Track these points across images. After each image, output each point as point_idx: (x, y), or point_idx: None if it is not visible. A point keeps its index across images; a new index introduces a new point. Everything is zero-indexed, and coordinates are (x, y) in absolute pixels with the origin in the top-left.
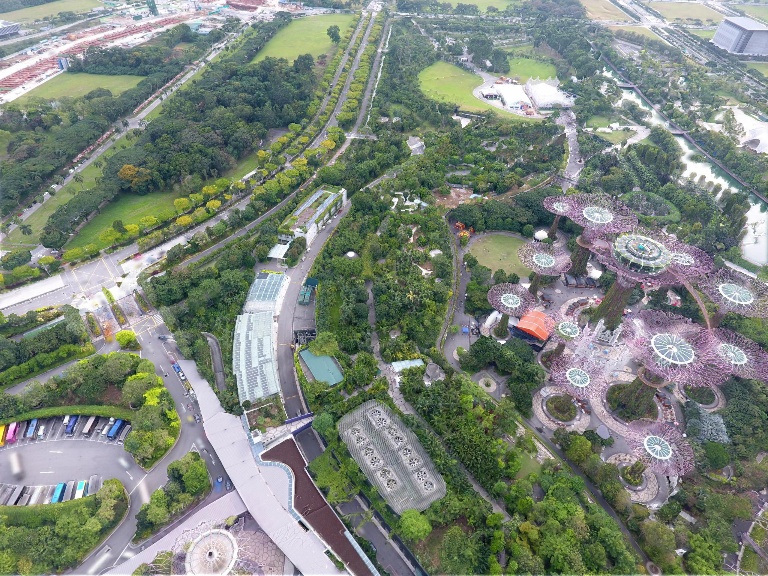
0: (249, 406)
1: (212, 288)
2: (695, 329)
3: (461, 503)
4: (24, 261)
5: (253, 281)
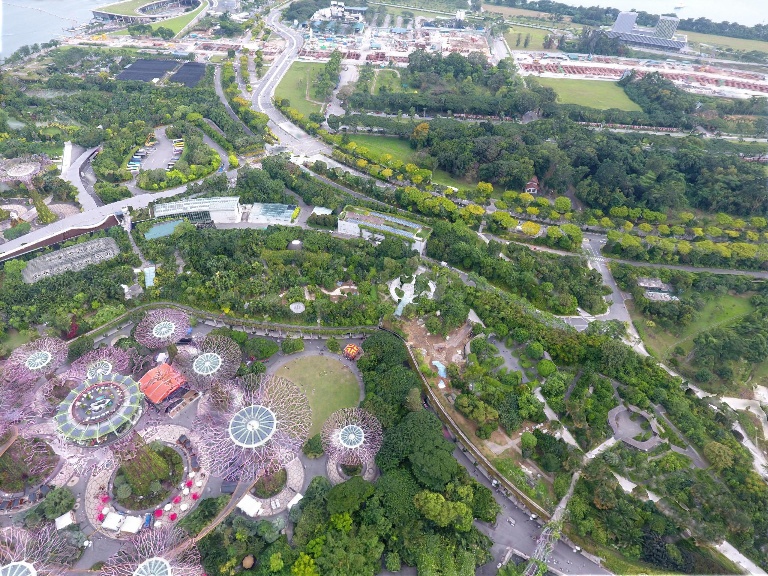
0: (149, 205)
1: (258, 176)
2: None
3: (8, 285)
4: (316, 120)
5: (285, 204)
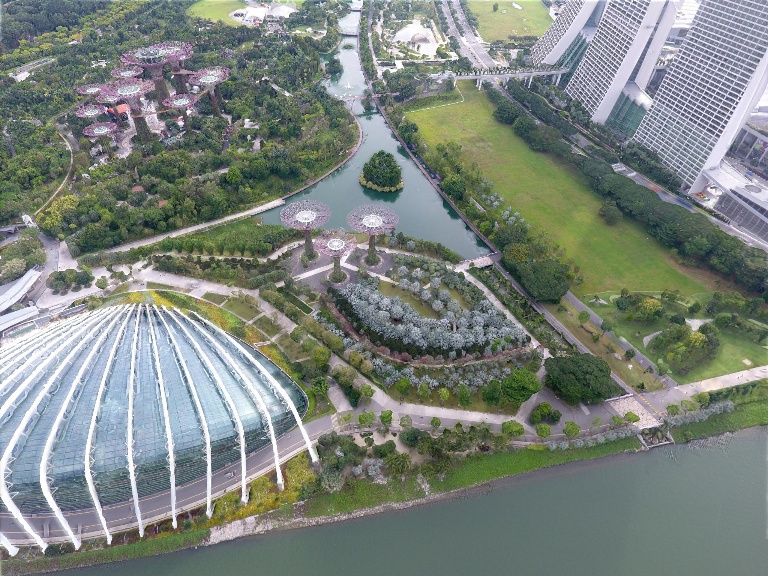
0: None
1: None
2: (150, 84)
3: None
4: None
5: None
